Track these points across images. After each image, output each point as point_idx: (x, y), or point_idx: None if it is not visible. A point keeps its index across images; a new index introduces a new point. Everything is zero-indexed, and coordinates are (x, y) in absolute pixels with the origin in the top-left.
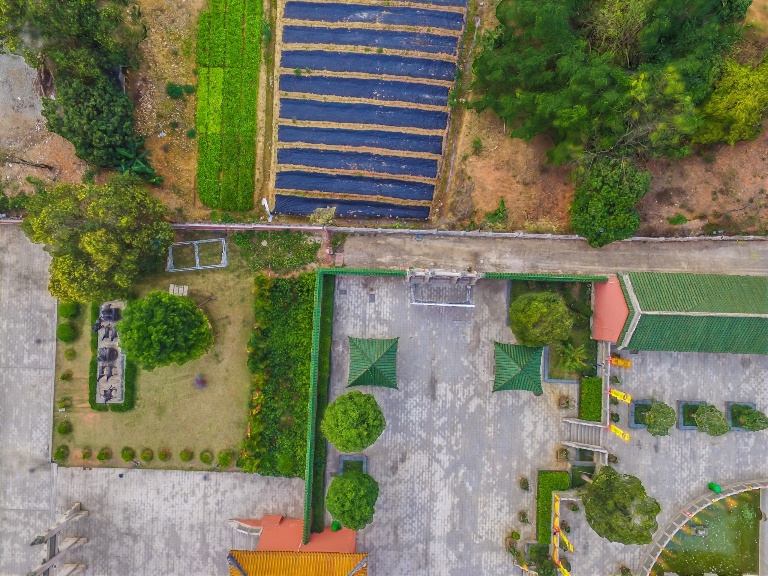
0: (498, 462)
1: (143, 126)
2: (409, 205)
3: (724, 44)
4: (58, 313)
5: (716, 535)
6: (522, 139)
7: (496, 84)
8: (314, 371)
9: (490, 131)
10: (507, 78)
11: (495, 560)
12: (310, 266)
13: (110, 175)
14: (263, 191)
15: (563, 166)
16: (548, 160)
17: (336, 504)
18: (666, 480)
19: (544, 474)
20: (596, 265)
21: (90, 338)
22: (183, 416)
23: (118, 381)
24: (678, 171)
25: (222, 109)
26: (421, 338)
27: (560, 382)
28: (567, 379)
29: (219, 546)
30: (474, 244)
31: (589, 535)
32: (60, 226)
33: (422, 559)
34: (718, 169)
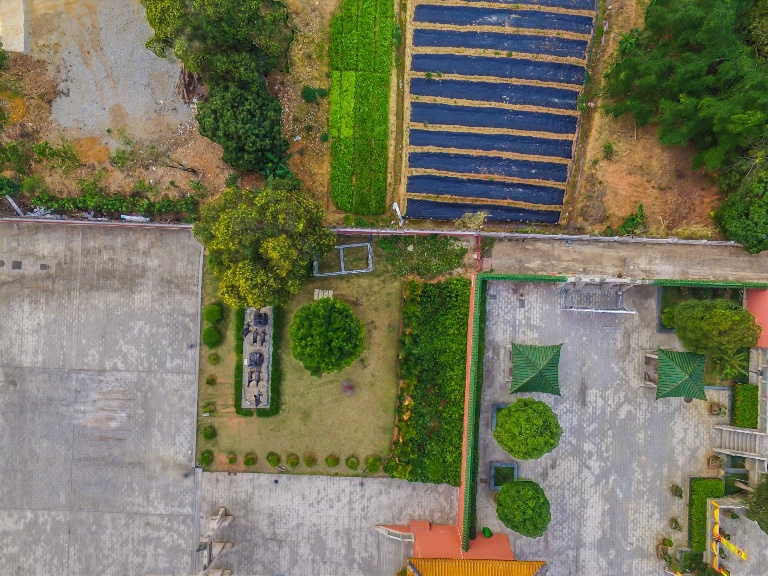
0: (649, 469)
1: (281, 130)
2: (540, 210)
3: None
4: (201, 317)
5: None
6: (656, 144)
7: (642, 89)
8: (475, 377)
9: (621, 135)
10: (658, 83)
11: (646, 567)
12: (456, 271)
13: (251, 179)
14: (394, 195)
15: (700, 171)
16: (693, 165)
17: (518, 512)
18: None
19: (699, 481)
20: (747, 271)
21: (234, 343)
22: (328, 421)
23: (264, 386)
24: None
25: (354, 113)
26: (571, 344)
27: (711, 389)
28: (719, 386)
29: (365, 552)
30: (624, 250)
31: (745, 543)
32: (245, 232)
33: (572, 566)
34: None
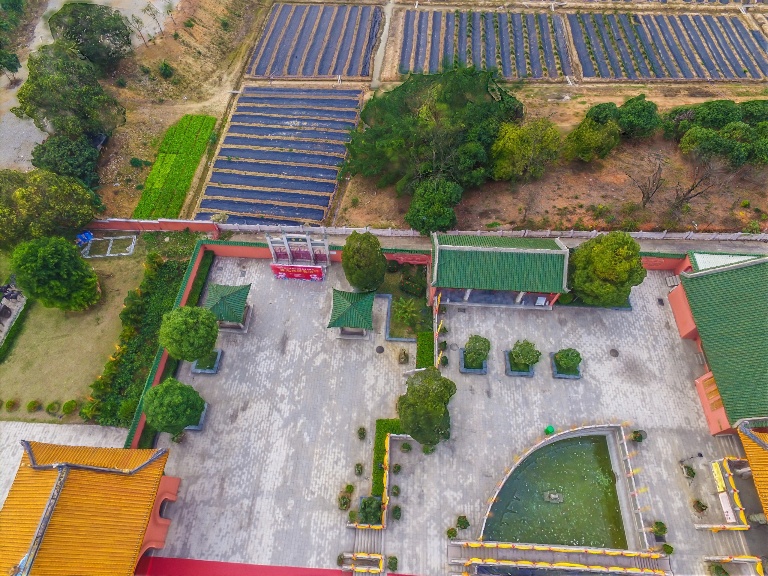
0: (338, 413)
1: (104, 177)
2: None
3: (503, 120)
4: None
5: (573, 503)
6: (387, 195)
7: (360, 153)
8: None
9: (365, 194)
10: None
11: (326, 521)
12: None
13: None
14: None
15: None
16: None
17: None
18: (501, 425)
19: (380, 419)
20: None
21: None
22: (46, 370)
23: (0, 337)
24: (494, 200)
25: (168, 175)
26: (279, 304)
27: (400, 341)
28: (406, 338)
29: None
30: (333, 239)
31: (424, 482)
32: (4, 180)
33: (245, 518)
34: (522, 197)
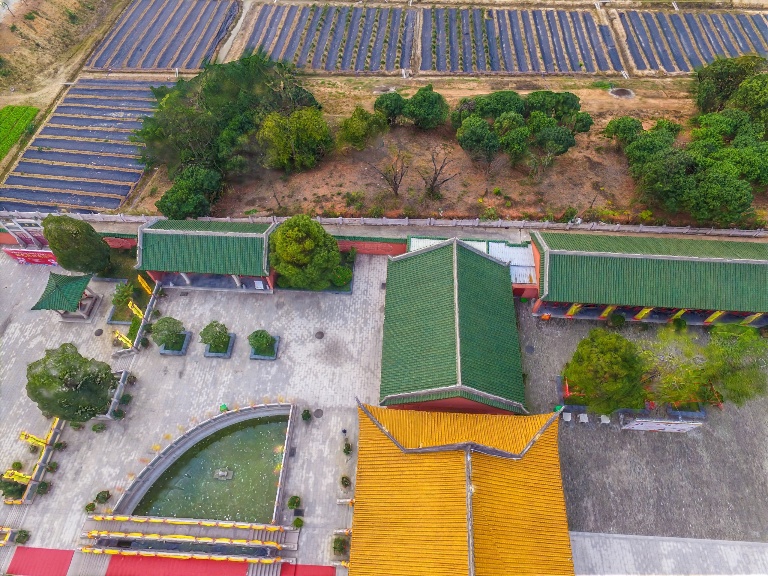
0: None
1: None
2: None
3: None
4: None
5: (242, 480)
6: None
7: None
8: None
9: (166, 183)
10: None
11: None
12: None
13: None
14: None
15: None
16: None
17: None
18: (182, 404)
19: None
20: None
21: None
22: None
23: None
24: (266, 188)
25: None
26: (14, 288)
27: (121, 324)
28: (127, 321)
29: None
30: None
31: (86, 459)
32: None
33: None
34: (291, 185)
